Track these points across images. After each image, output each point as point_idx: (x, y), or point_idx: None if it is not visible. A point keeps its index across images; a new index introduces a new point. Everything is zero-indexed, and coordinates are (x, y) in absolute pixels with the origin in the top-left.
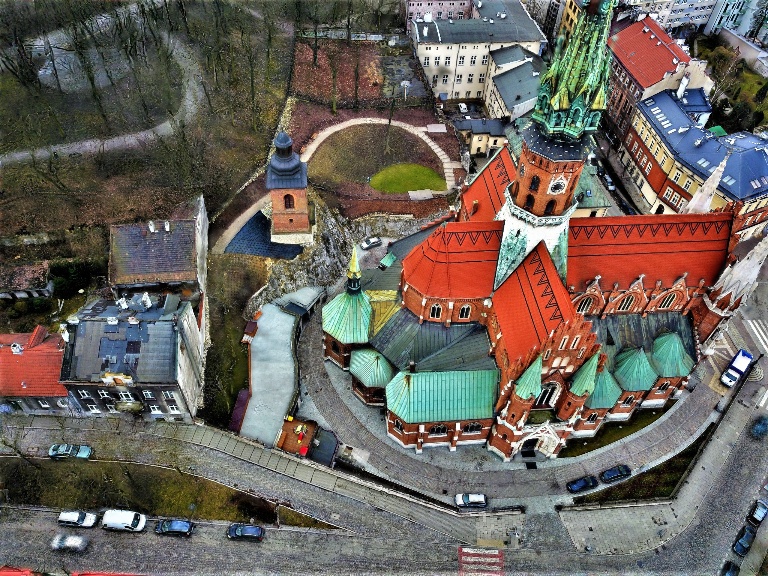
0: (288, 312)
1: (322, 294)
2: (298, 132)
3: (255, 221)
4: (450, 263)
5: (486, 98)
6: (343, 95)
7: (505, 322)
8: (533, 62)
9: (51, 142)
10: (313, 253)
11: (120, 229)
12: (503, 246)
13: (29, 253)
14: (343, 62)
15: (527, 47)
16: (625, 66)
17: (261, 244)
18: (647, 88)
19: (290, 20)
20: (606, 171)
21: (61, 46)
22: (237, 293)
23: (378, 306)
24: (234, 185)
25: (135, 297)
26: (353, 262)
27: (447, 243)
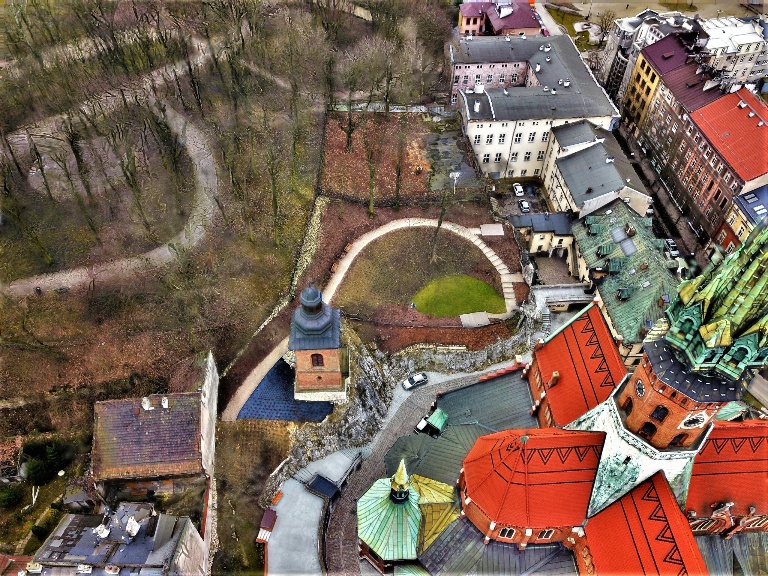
0: (315, 493)
1: (356, 461)
2: (328, 243)
3: (275, 372)
4: (530, 485)
5: (545, 178)
6: (381, 187)
7: (607, 575)
8: (604, 142)
9: (35, 270)
10: (346, 413)
11: (107, 406)
12: (603, 468)
13: (2, 419)
14: (380, 142)
15: (598, 127)
16: (718, 150)
17: (282, 404)
18: (748, 181)
19: (320, 88)
20: (693, 273)
21: (58, 136)
22: (252, 472)
23: (429, 510)
24: (251, 325)
25: (120, 511)
26: (400, 475)
27: (527, 462)
